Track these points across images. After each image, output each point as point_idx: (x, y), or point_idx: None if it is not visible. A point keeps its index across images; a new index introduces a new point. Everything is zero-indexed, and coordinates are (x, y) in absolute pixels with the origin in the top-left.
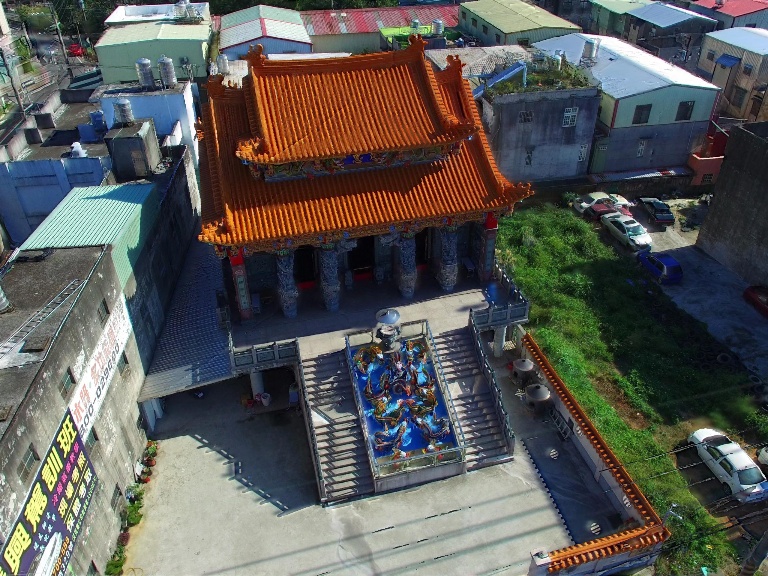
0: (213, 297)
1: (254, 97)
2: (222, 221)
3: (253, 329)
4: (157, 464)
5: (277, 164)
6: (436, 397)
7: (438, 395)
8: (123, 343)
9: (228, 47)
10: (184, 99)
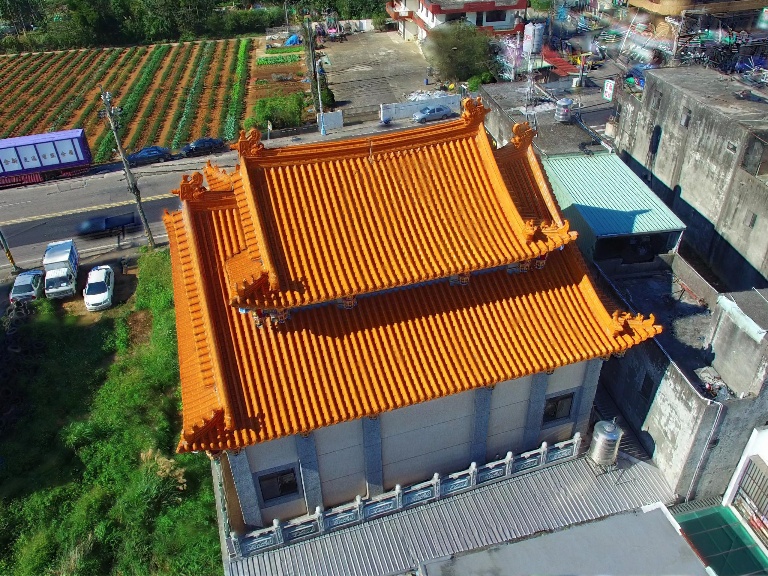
0: None
1: None
2: None
3: None
4: None
5: None
6: None
7: None
8: None
9: None
10: None
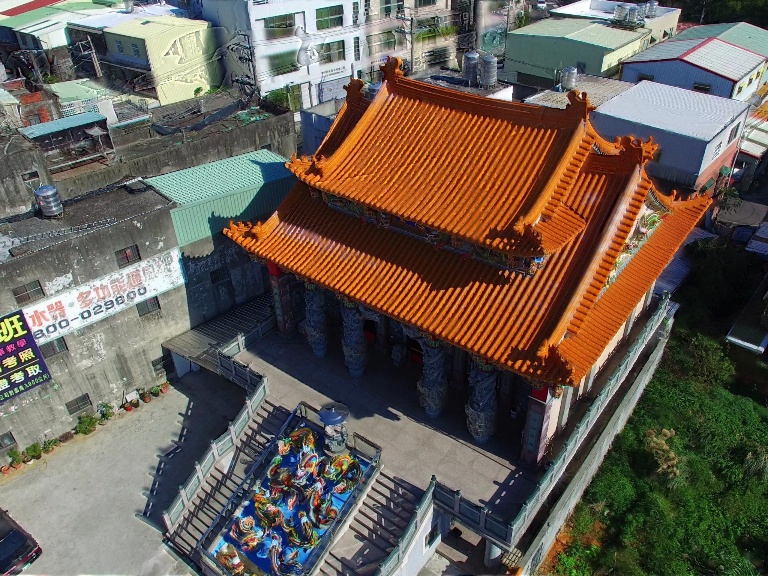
0: None
1: None
2: None
3: (280, 344)
4: (149, 403)
5: None
6: None
7: (327, 537)
8: (159, 290)
9: (632, 62)
10: None
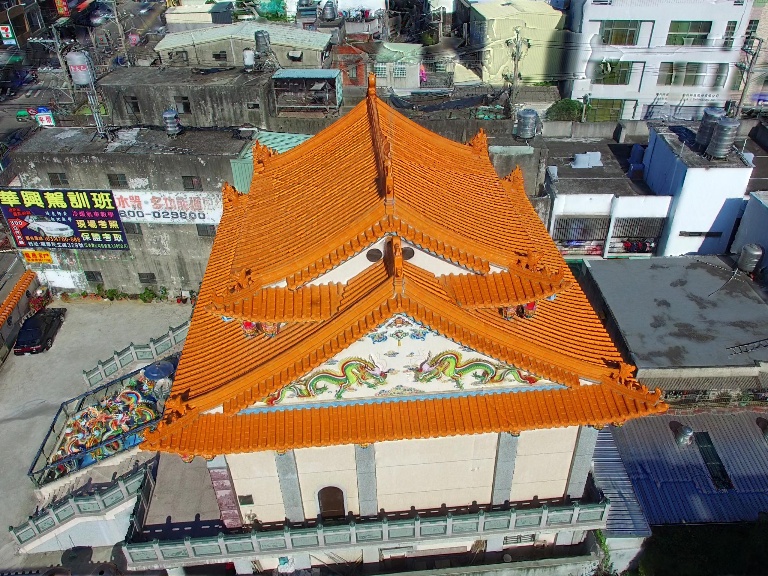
0: None
1: None
2: None
3: None
4: None
5: None
6: None
7: None
8: (216, 221)
9: None
10: (686, 175)
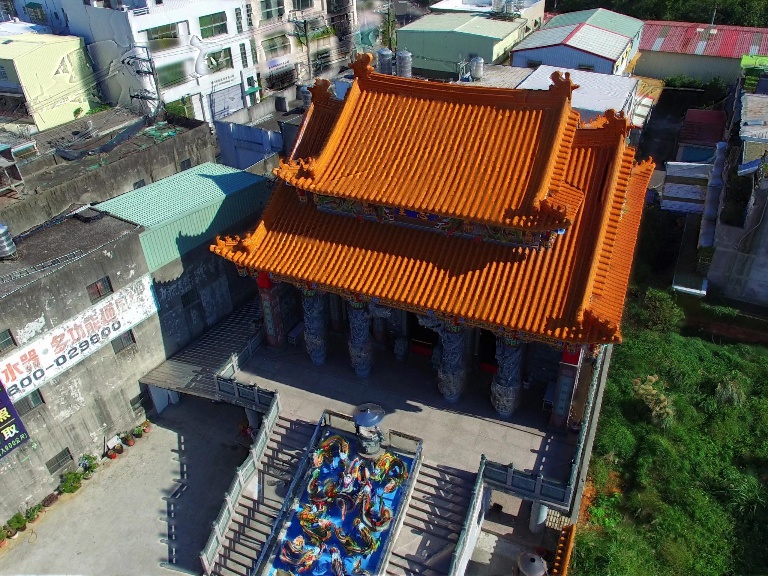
0: None
1: (341, 112)
2: (246, 237)
3: (274, 358)
4: (133, 446)
5: (320, 194)
6: (383, 539)
7: (385, 539)
8: (132, 322)
9: (520, 50)
10: None
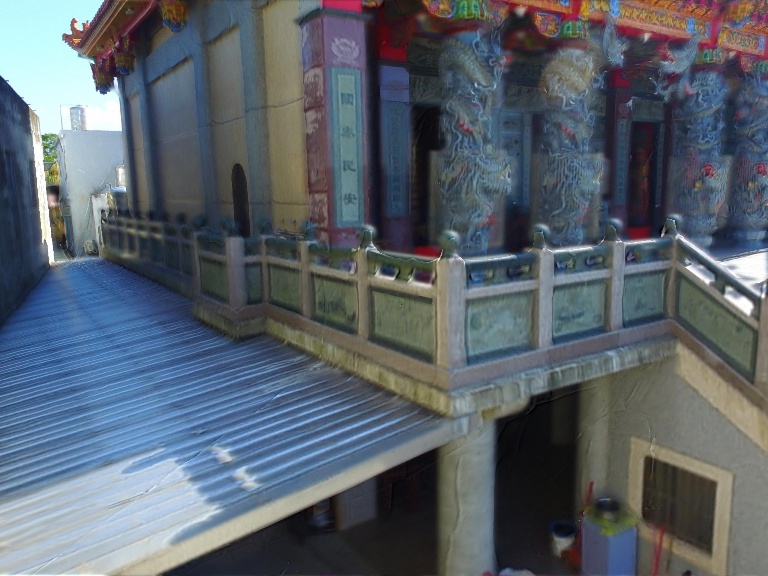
0: (154, 310)
1: None
2: None
3: None
4: None
5: None
6: None
7: None
8: None
9: None
10: None
